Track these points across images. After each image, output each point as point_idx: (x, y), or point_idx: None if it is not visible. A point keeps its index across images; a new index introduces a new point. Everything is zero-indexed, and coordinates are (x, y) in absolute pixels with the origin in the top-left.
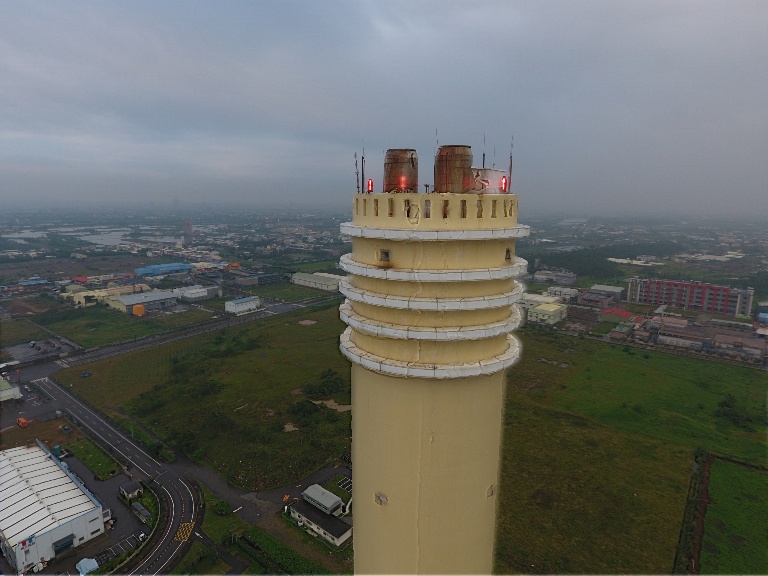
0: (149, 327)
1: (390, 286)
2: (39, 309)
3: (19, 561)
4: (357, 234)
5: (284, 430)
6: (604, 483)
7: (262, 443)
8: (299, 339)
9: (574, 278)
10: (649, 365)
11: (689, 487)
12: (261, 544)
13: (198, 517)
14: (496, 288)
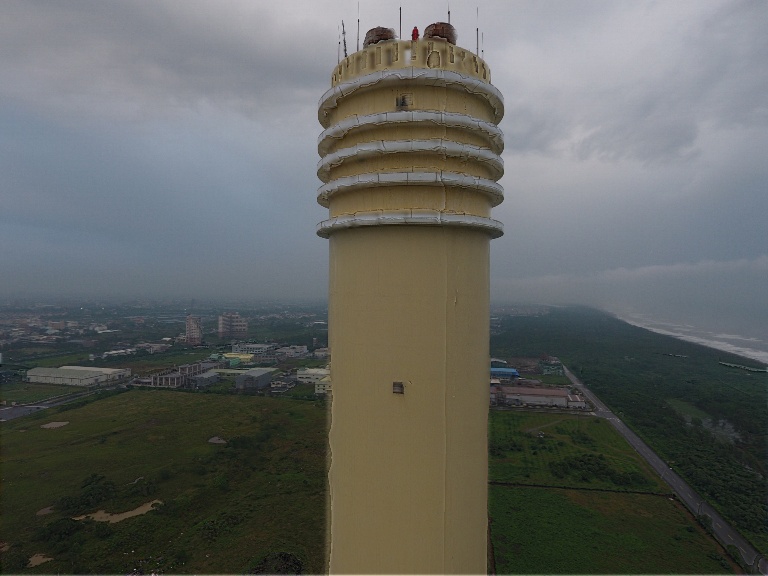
0: None
1: (414, 131)
2: None
3: None
4: (372, 80)
5: (28, 565)
6: None
7: None
8: (43, 446)
9: None
10: None
11: None
12: None
13: None
14: (495, 151)
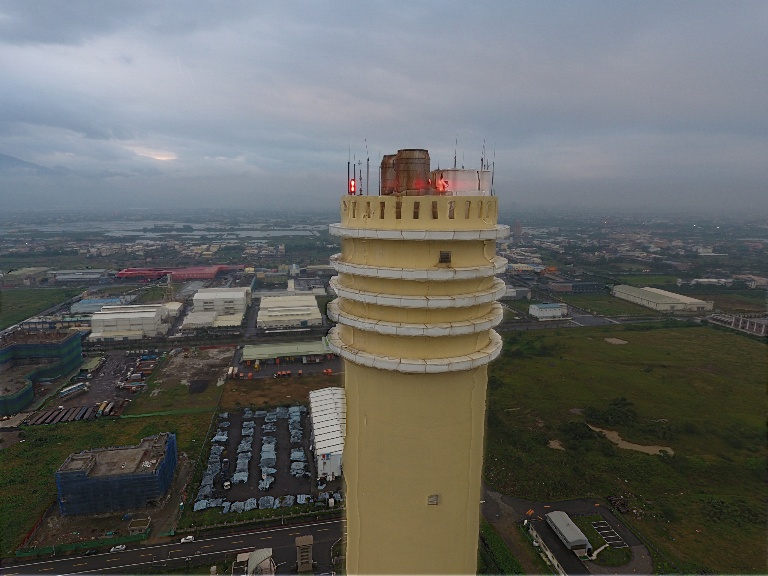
0: None
1: (340, 276)
2: None
3: (319, 468)
4: None
5: (548, 445)
6: None
7: (521, 450)
8: (599, 357)
9: None
10: None
11: None
12: (491, 543)
13: None
14: (419, 289)
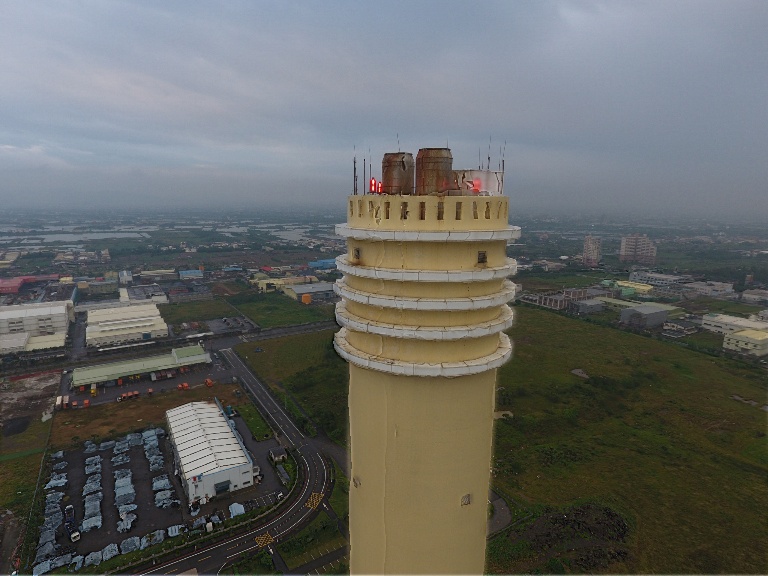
0: (313, 315)
1: (360, 282)
2: (233, 291)
3: (191, 492)
4: None
5: None
6: None
7: None
8: None
9: None
10: None
11: None
12: None
13: (327, 490)
14: (461, 291)
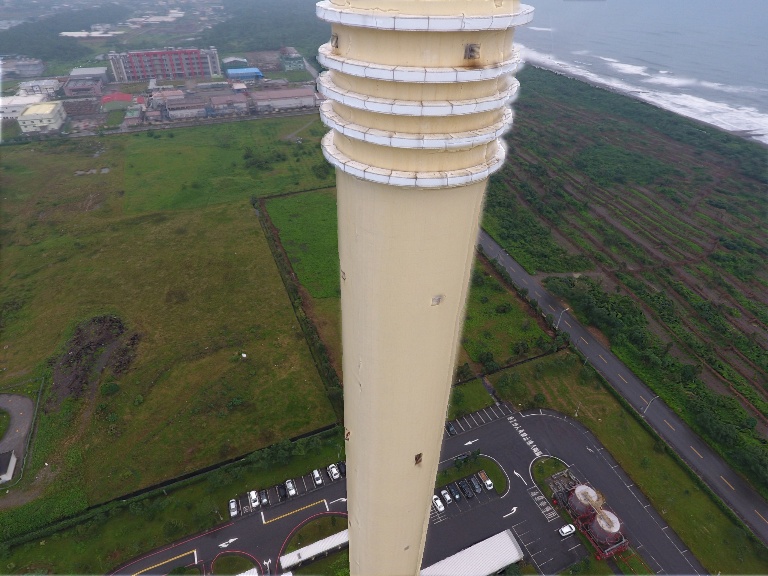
0: None
1: (476, 88)
2: None
3: None
4: (446, 28)
5: None
6: (211, 257)
7: None
8: None
9: (41, 65)
10: (178, 143)
11: (262, 228)
12: None
13: None
14: None
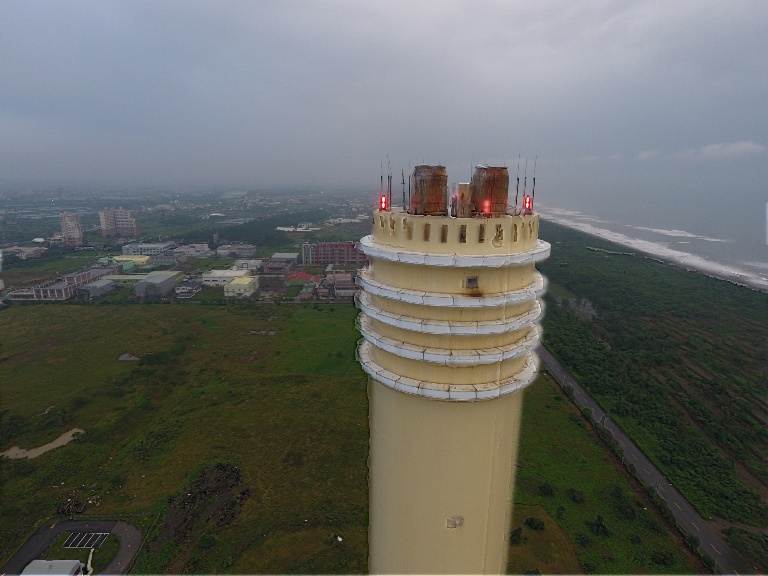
0: None
1: (478, 312)
2: None
3: None
4: (440, 263)
5: None
6: (335, 425)
7: None
8: None
9: (254, 249)
10: (336, 316)
11: None
12: None
13: None
14: None
